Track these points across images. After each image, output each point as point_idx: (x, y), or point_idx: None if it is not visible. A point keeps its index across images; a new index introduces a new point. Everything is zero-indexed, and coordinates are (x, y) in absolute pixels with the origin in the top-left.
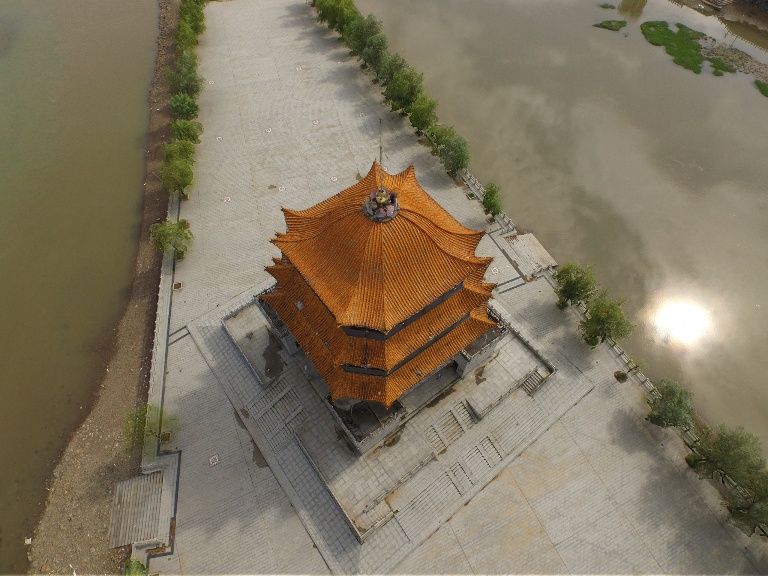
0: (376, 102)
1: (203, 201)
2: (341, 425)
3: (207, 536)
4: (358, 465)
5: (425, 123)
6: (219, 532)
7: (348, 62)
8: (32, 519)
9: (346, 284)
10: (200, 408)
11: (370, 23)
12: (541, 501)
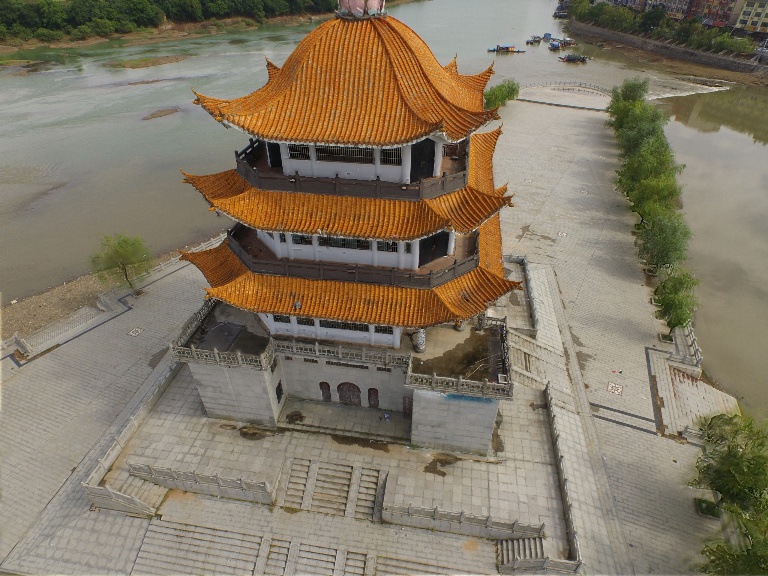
0: (612, 190)
1: None
2: None
3: (49, 377)
4: (193, 422)
5: None
6: (57, 382)
7: (611, 159)
8: (35, 292)
9: None
10: (183, 293)
11: (653, 118)
12: None
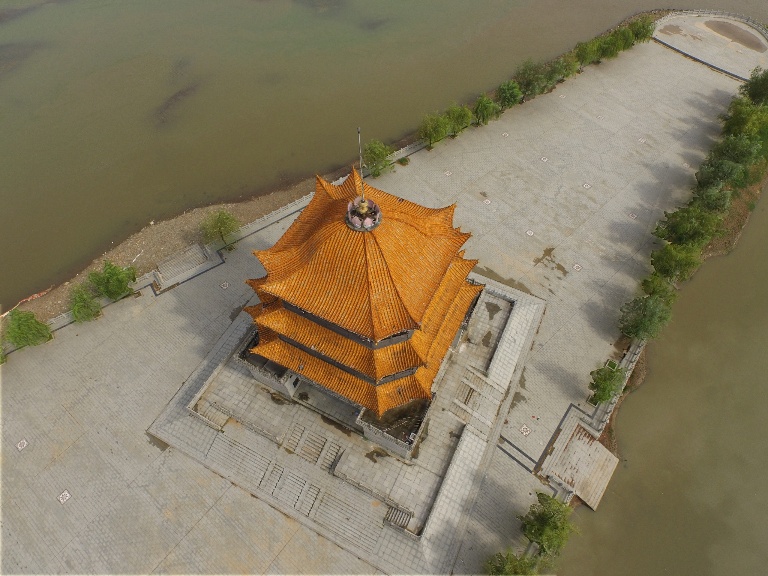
0: (663, 219)
1: (435, 160)
2: (250, 338)
3: (172, 310)
4: (247, 381)
5: (667, 271)
6: (177, 315)
7: (695, 170)
8: (165, 217)
9: (298, 242)
10: None
11: (748, 150)
12: (280, 575)
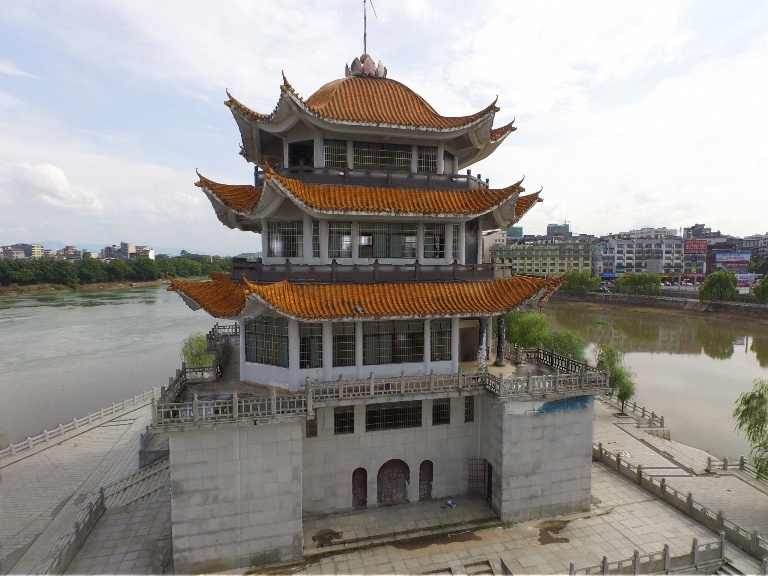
0: None
1: None
2: None
3: None
4: None
5: (534, 343)
6: None
7: None
8: None
9: None
10: (38, 480)
11: None
12: None
